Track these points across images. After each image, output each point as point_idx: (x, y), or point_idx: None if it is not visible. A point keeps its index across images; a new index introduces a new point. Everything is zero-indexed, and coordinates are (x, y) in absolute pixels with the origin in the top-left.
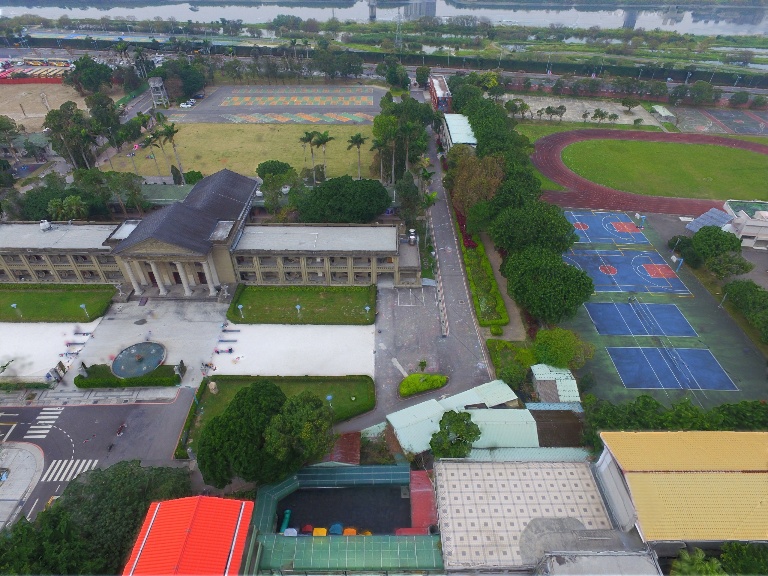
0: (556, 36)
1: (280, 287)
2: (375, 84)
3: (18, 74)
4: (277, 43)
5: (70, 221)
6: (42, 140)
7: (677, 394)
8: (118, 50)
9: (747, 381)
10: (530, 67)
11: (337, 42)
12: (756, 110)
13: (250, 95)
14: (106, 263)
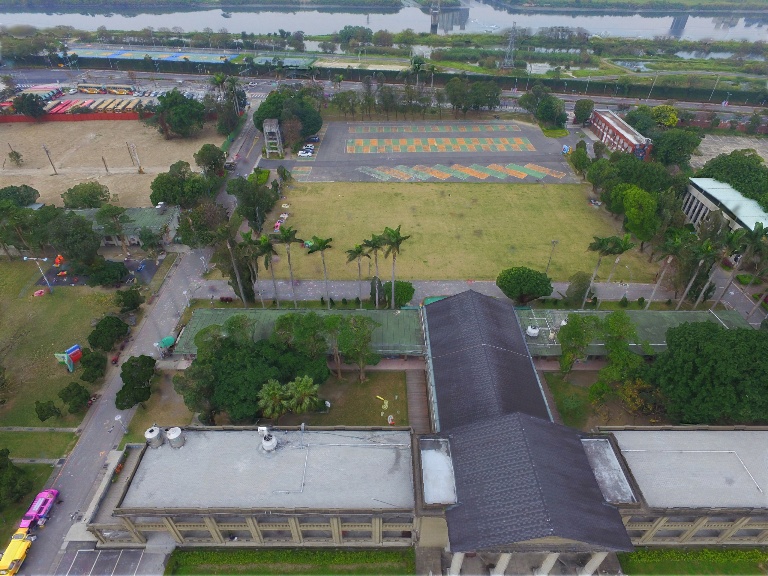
0: (665, 50)
1: (681, 550)
2: (516, 119)
3: (80, 109)
4: (357, 61)
5: (303, 426)
6: (156, 221)
7: None
8: (217, 83)
9: None
10: (690, 95)
11: (427, 59)
12: None
13: (374, 136)
14: (390, 520)
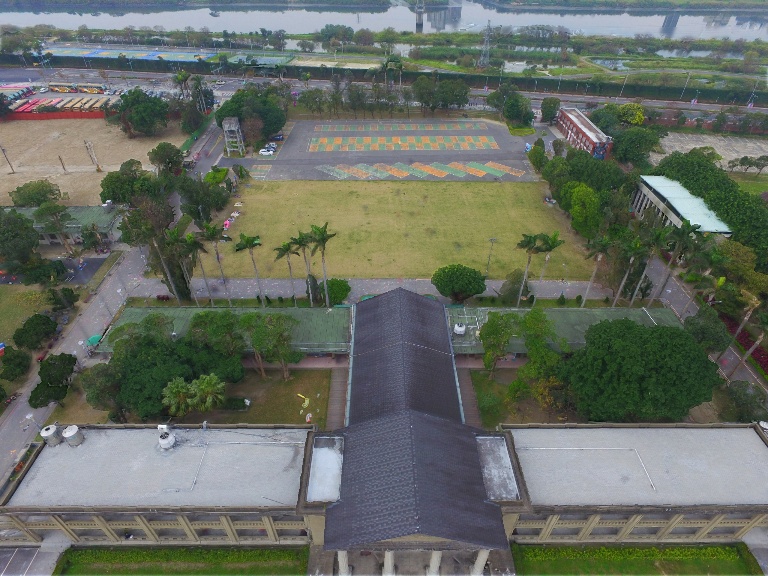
0: (646, 49)
1: (579, 547)
2: (484, 117)
3: (46, 107)
4: None
5: (205, 424)
6: (102, 220)
7: None
8: (179, 81)
9: None
10: (661, 93)
11: (405, 58)
12: None
13: (339, 135)
14: (283, 518)
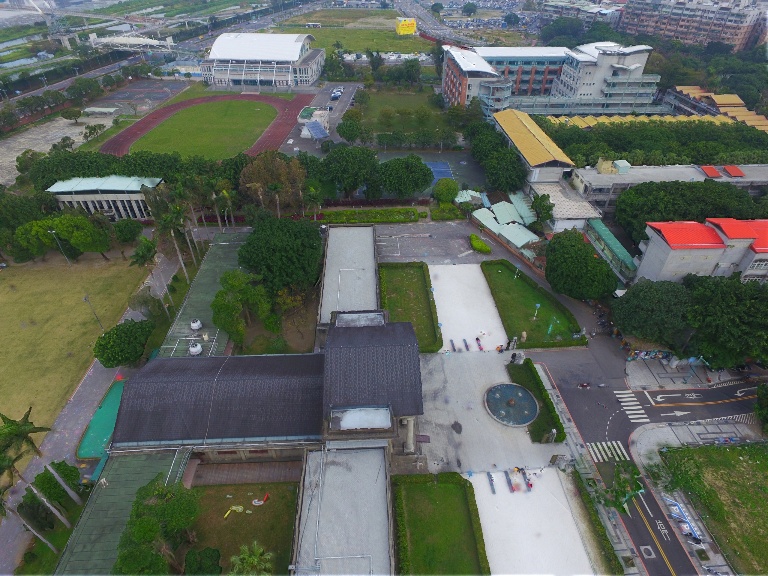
0: None
1: None
2: None
3: None
4: None
5: (293, 566)
6: None
7: (456, 175)
8: None
9: (441, 159)
10: None
11: None
12: (123, 87)
13: None
14: None
